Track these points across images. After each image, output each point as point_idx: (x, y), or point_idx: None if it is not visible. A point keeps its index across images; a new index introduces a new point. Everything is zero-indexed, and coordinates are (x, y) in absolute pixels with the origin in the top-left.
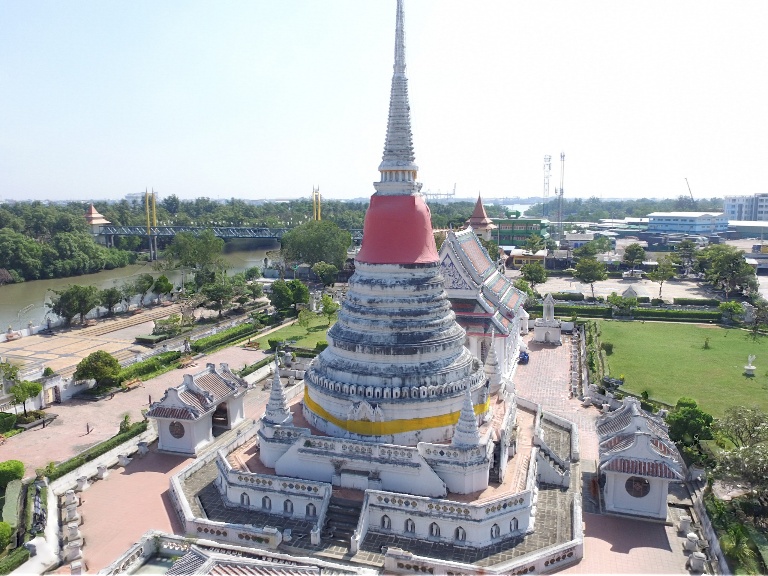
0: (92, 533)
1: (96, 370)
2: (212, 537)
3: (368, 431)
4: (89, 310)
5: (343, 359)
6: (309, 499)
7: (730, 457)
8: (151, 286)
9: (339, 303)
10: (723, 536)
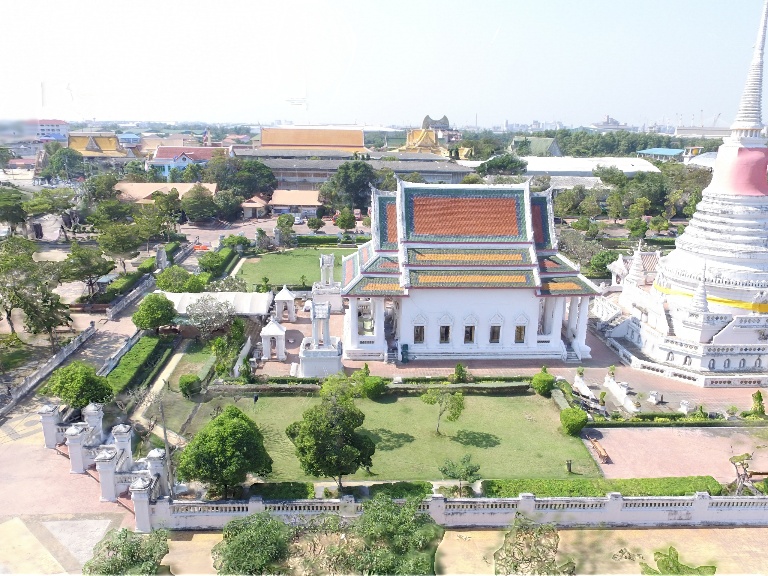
0: None
1: None
2: None
3: None
4: None
5: None
6: None
7: None
8: None
9: None
10: None
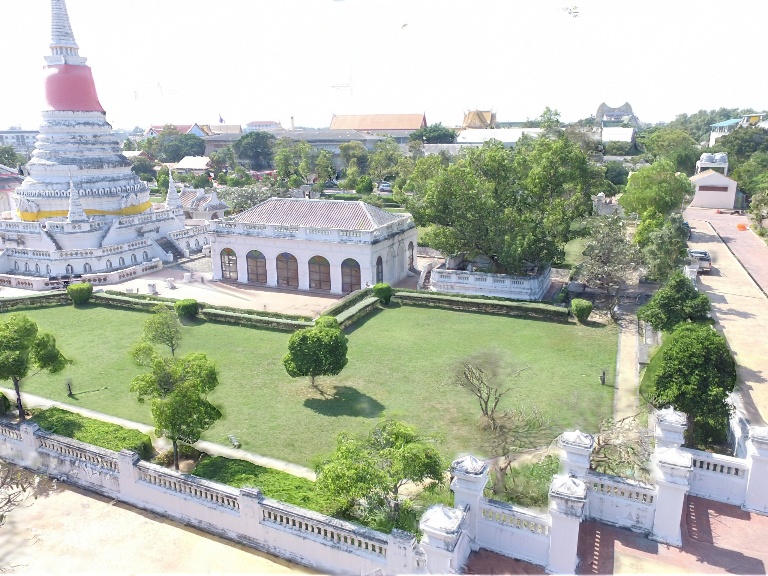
0: None
1: None
2: (129, 278)
3: (135, 212)
4: None
5: (92, 176)
6: (145, 248)
7: (237, 195)
8: None
9: None
10: None
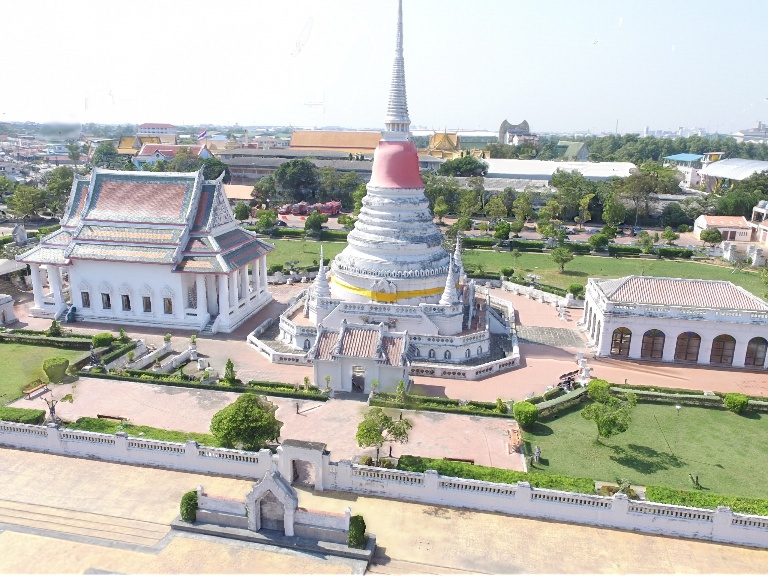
0: (540, 391)
1: (272, 415)
2: None
3: None
4: None
5: (434, 253)
6: None
7: None
8: None
9: None
10: (468, 274)
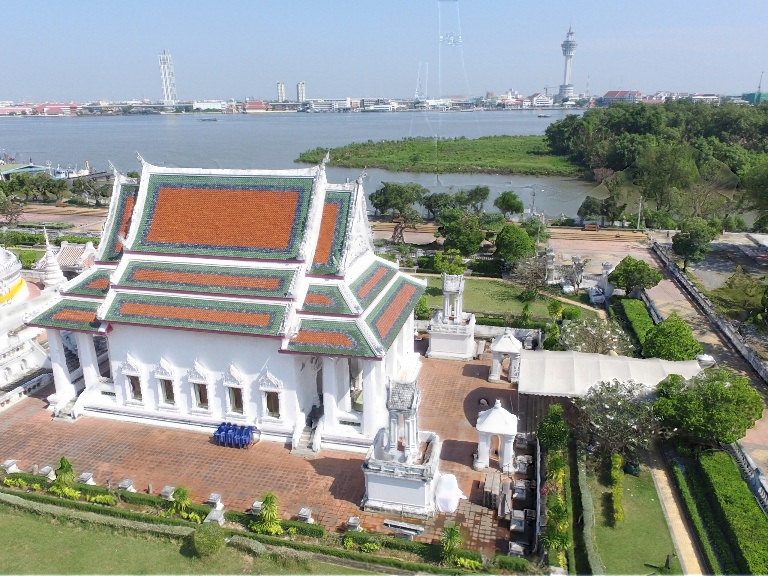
0: None
1: None
2: None
3: None
4: (401, 208)
5: None
6: None
7: None
8: (487, 200)
9: (595, 284)
10: None
